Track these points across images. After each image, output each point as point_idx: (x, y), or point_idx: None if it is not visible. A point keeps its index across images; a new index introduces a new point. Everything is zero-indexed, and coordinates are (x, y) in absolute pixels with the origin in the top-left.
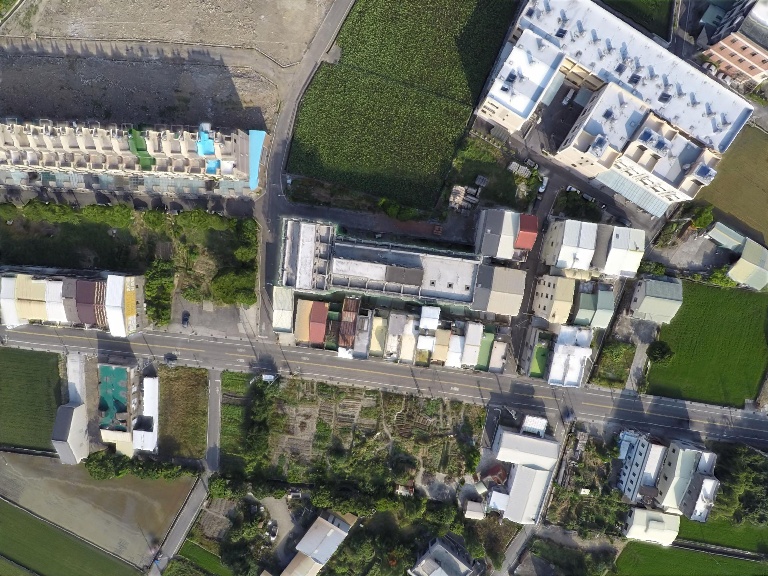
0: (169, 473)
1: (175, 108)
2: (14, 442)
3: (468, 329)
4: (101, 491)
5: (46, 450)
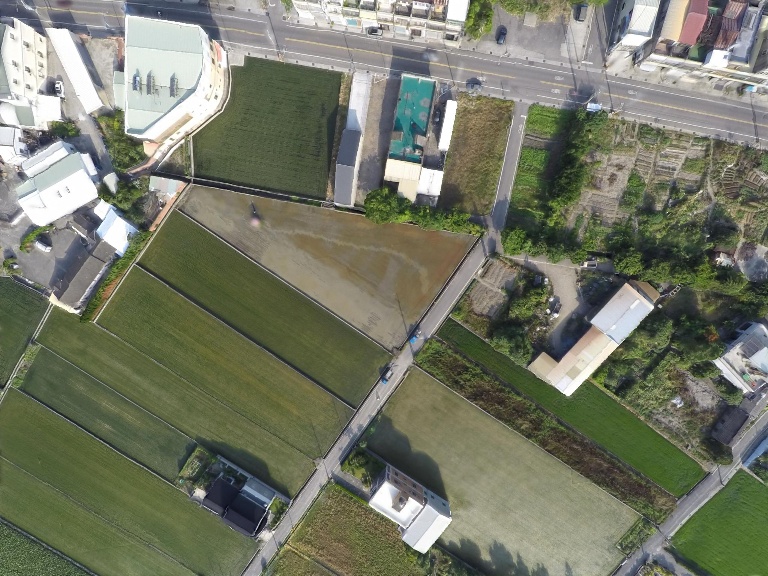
0: (460, 219)
1: None
2: (268, 185)
3: None
4: (361, 250)
5: (305, 196)
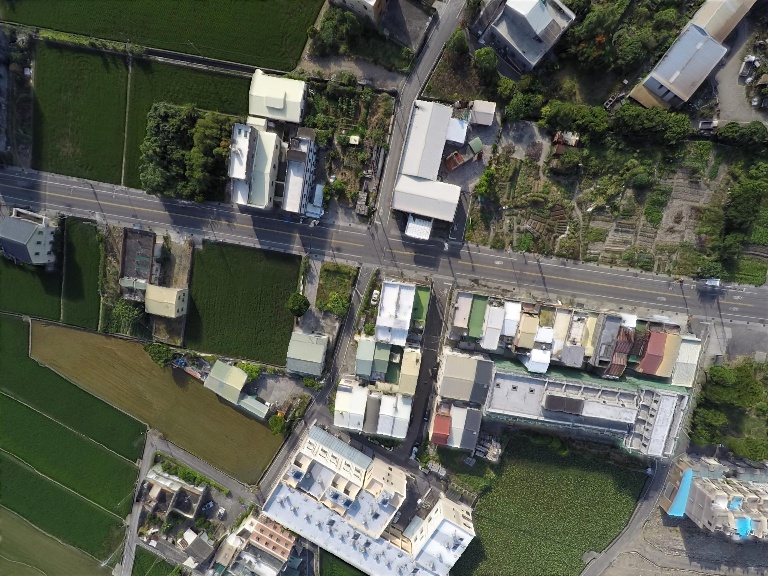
0: None
1: None
2: None
3: None
4: None
5: None
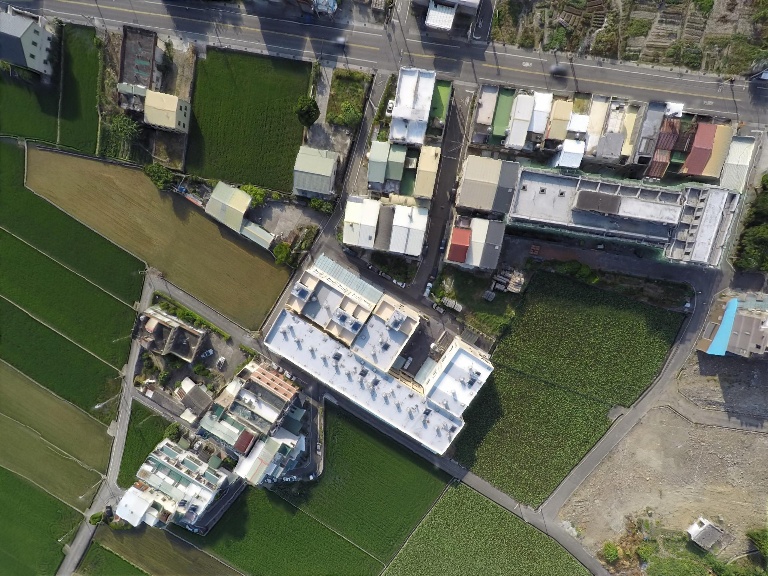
0: None
1: None
2: None
3: None
4: None
5: None
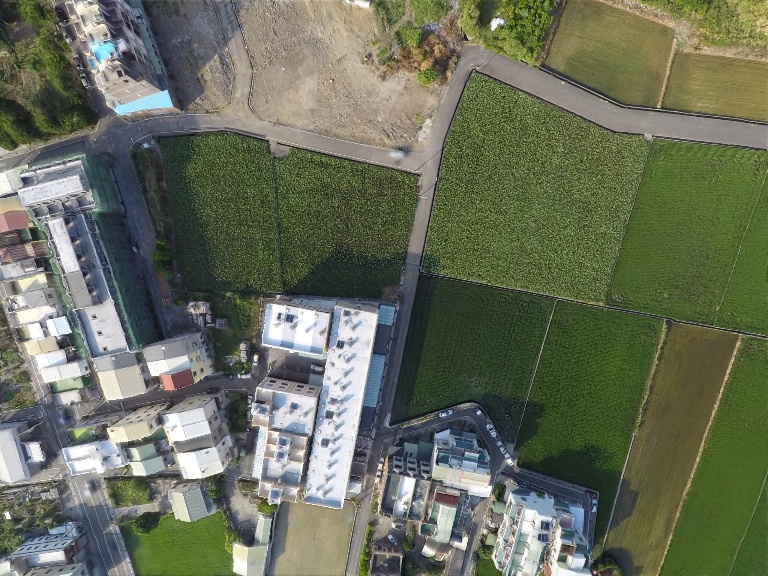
0: None
1: (166, 2)
2: None
3: (72, 363)
4: None
5: None
